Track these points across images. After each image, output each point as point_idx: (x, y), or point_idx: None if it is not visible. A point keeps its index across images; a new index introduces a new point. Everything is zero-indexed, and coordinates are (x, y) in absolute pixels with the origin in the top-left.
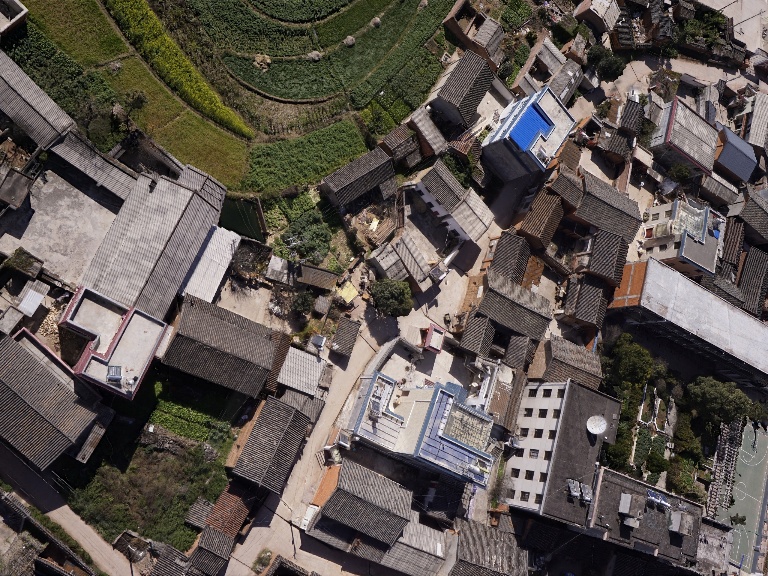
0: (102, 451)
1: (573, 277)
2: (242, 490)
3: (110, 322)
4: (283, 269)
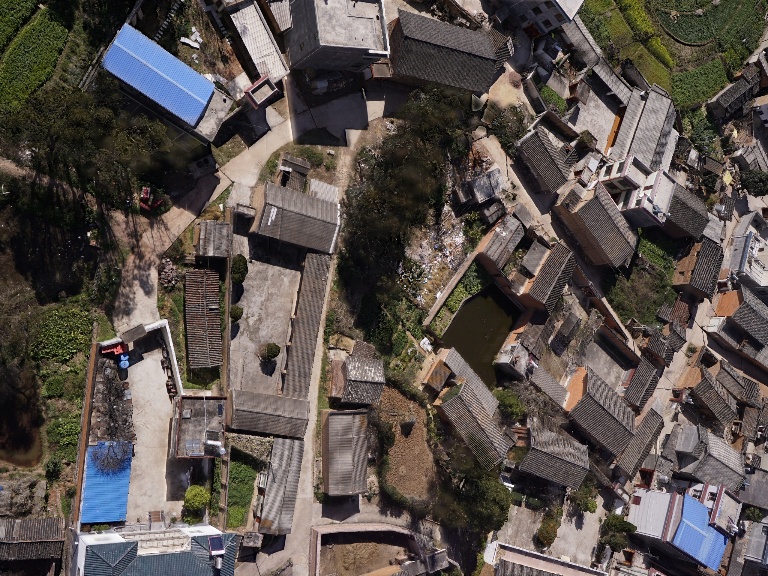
0: (621, 265)
1: None
2: (688, 300)
3: (641, 180)
4: (696, 158)
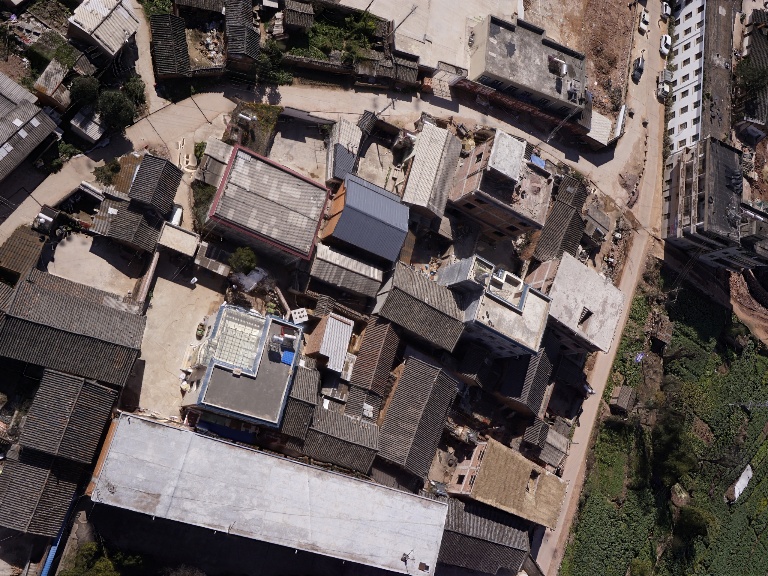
0: None
1: (12, 450)
2: None
3: None
4: None
